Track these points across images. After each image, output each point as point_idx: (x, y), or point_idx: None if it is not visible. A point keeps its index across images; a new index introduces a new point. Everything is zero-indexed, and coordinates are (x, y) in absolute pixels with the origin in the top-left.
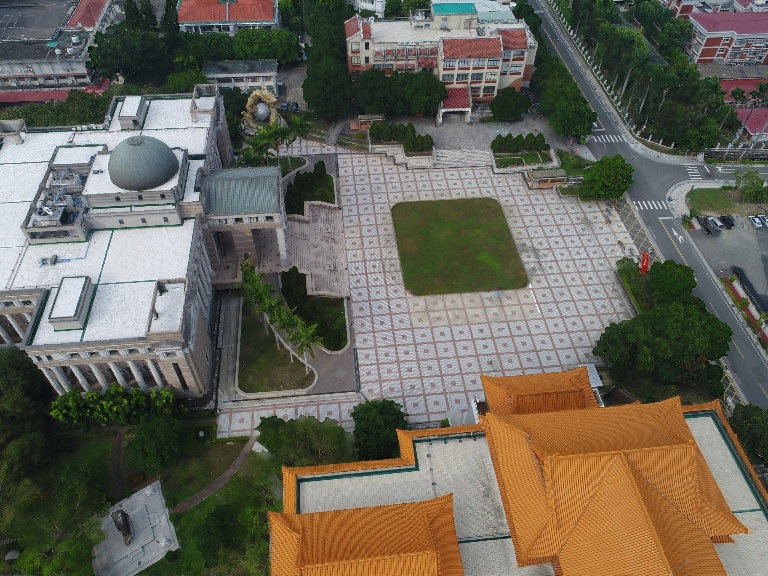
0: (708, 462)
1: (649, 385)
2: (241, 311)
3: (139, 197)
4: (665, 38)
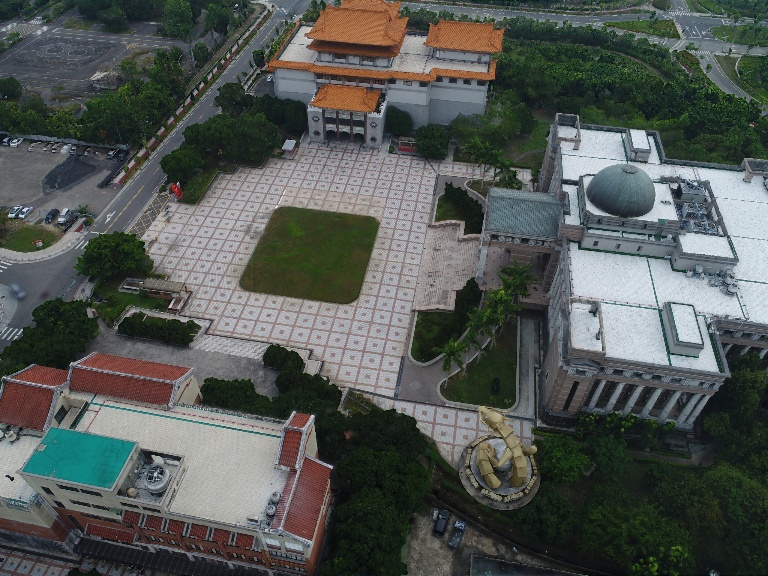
0: (296, 54)
1: None
2: None
3: None
4: None
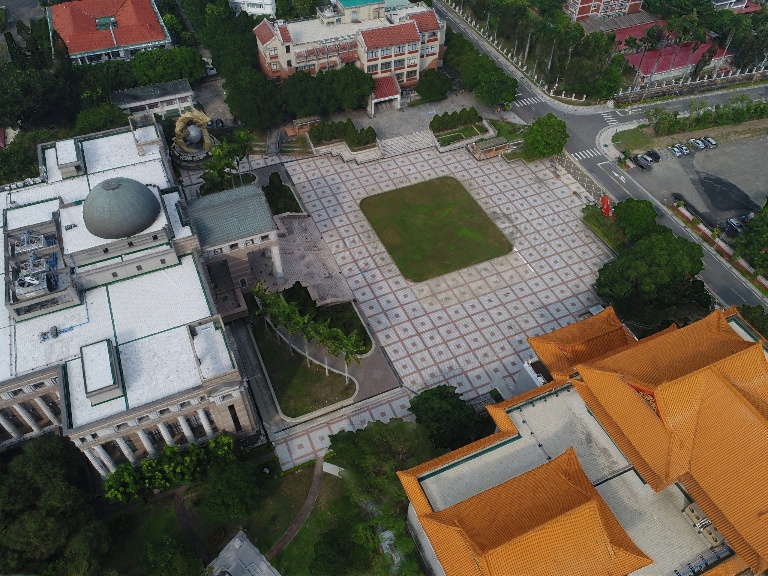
0: None
1: (649, 312)
2: (253, 339)
3: (129, 244)
4: (545, 2)
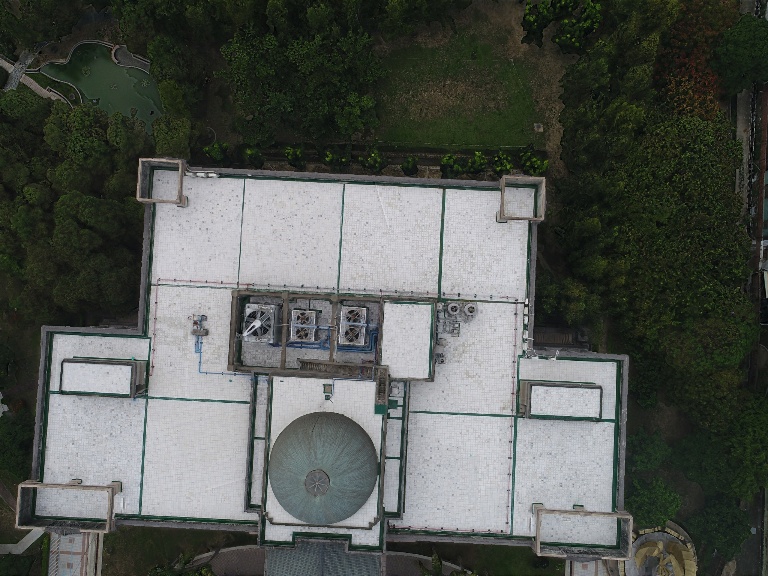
0: None
1: None
2: None
3: None
4: None
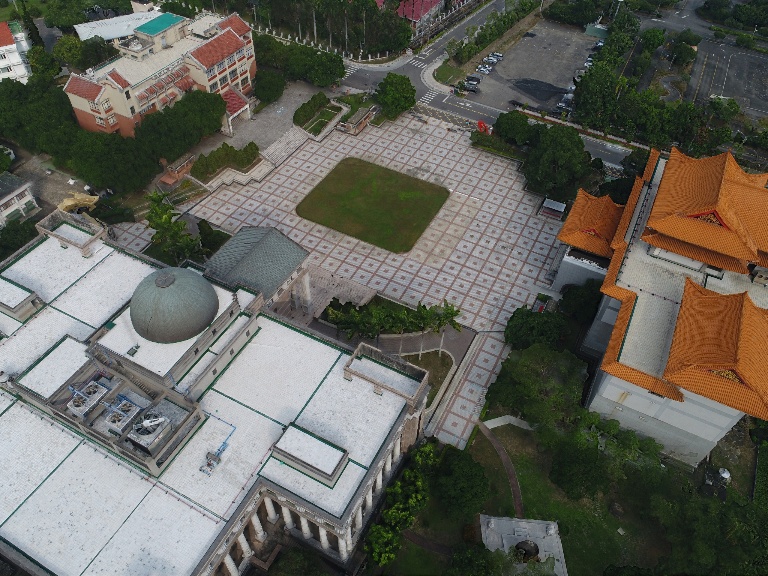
0: None
1: (571, 189)
2: None
3: (213, 332)
4: None
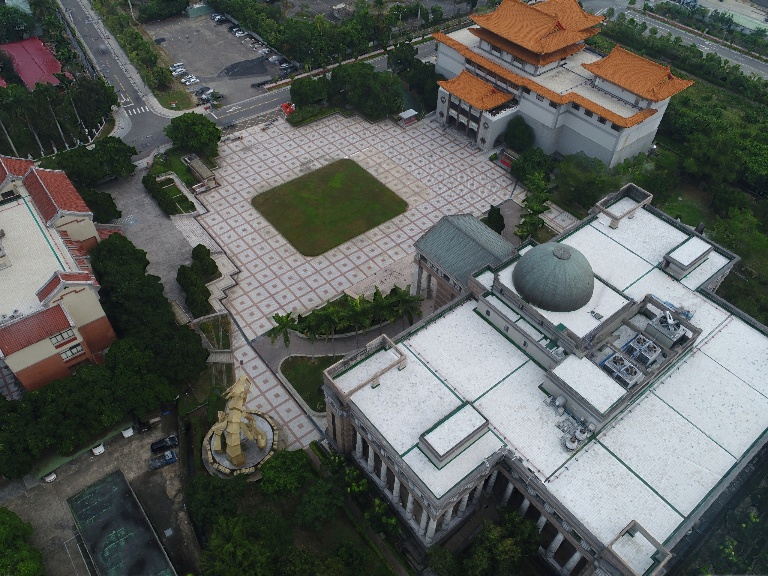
0: None
1: None
2: None
3: None
4: None
